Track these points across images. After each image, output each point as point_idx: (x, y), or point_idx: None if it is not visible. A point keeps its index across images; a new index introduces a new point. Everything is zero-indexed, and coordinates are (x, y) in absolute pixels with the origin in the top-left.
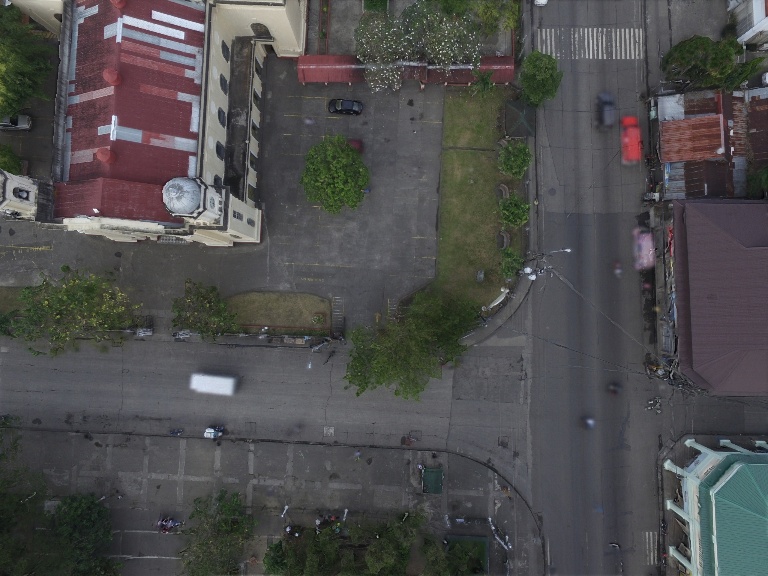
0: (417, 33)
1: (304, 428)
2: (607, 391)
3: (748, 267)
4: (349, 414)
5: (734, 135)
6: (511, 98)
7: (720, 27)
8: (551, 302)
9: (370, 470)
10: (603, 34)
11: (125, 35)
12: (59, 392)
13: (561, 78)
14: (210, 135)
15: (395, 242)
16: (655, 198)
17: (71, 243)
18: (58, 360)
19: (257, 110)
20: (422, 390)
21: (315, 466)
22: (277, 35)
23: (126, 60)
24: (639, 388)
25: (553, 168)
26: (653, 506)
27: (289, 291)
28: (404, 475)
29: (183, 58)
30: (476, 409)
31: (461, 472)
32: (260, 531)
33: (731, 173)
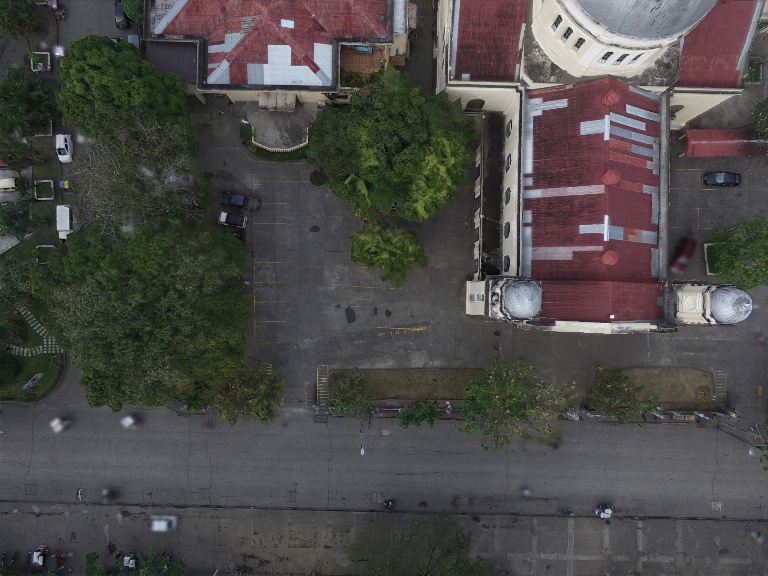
0: None
1: (692, 504)
2: None
3: None
4: (736, 488)
5: None
6: None
7: None
8: None
9: (759, 544)
10: None
11: (611, 132)
12: (443, 474)
13: None
14: None
15: None
16: None
17: (449, 323)
18: (441, 442)
19: None
20: None
21: (704, 542)
22: (682, 113)
23: (612, 158)
24: None
25: None
26: None
27: (670, 366)
28: None
29: (645, 150)
30: None
31: None
32: None
33: None
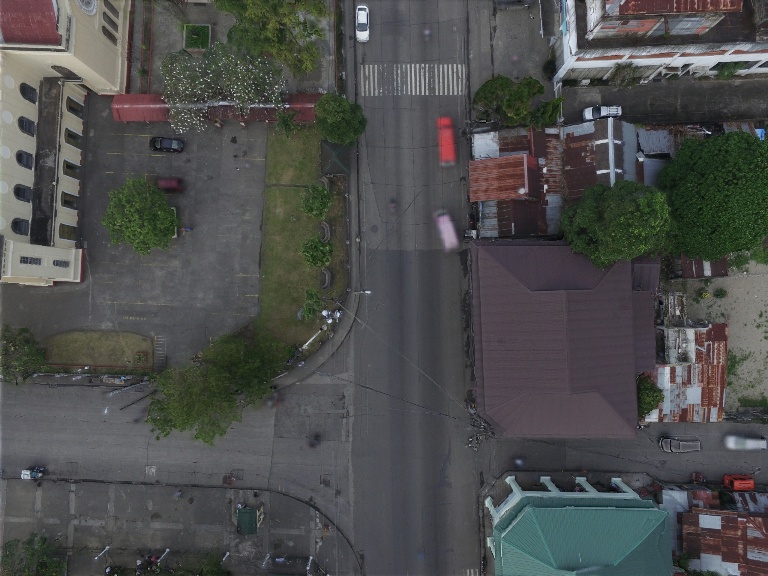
0: (215, 75)
1: (125, 468)
2: (428, 428)
3: (533, 311)
4: (171, 453)
5: (548, 172)
6: None
7: (542, 62)
8: (373, 339)
9: (192, 509)
10: (426, 70)
11: None
12: None
13: (360, 119)
14: (2, 180)
15: (218, 280)
16: (473, 235)
17: None
18: None
19: (75, 149)
20: (223, 433)
21: (136, 506)
22: (84, 76)
23: None
24: (460, 425)
25: (375, 205)
26: (474, 543)
27: (111, 330)
28: (226, 514)
29: None
30: (298, 447)
31: (283, 511)
32: (80, 572)
33: (544, 211)
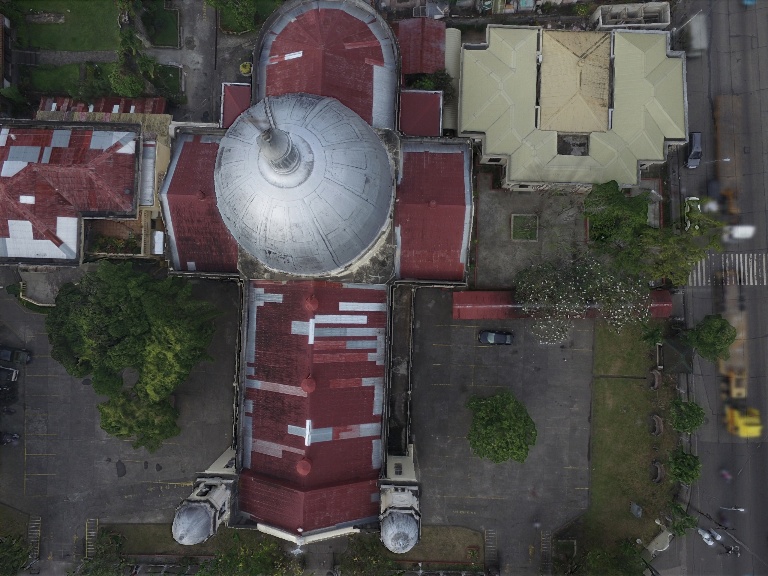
0: (588, 293)
1: None
2: None
3: None
4: None
5: None
6: (663, 326)
7: None
8: None
9: None
10: (754, 259)
11: (317, 335)
12: None
13: None
14: None
15: (547, 473)
16: None
17: None
18: None
19: None
20: None
21: None
22: None
23: (318, 360)
24: None
25: (705, 397)
26: None
27: (441, 524)
28: None
29: (366, 342)
30: None
31: None
32: None
33: None
